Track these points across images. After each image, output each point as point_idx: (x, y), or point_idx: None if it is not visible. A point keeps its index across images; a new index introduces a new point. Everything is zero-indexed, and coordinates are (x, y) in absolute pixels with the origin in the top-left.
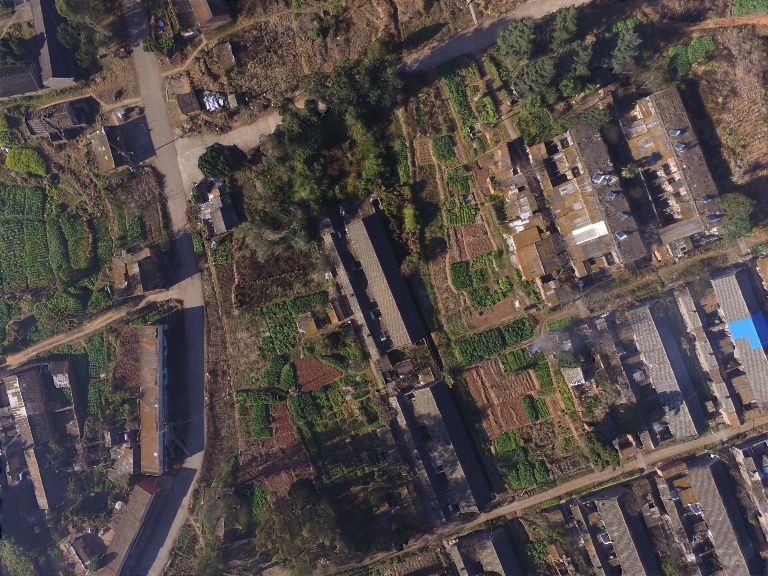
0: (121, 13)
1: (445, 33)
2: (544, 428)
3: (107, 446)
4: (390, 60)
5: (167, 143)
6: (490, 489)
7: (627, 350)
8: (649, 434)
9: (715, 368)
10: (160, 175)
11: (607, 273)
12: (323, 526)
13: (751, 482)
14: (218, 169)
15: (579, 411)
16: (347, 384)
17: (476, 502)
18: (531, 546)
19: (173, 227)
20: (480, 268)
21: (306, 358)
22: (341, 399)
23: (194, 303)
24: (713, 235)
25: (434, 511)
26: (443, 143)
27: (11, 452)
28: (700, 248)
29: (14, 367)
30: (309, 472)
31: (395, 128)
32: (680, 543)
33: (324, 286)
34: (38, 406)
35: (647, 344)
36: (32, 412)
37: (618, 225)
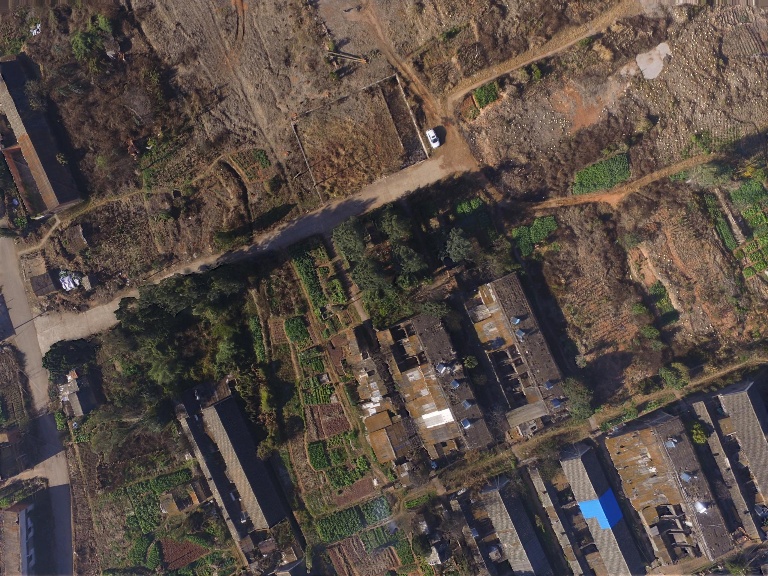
0: None
1: (294, 214)
2: None
3: None
4: (241, 241)
5: (26, 322)
6: None
7: None
8: None
9: (568, 546)
10: (20, 354)
11: (462, 450)
12: None
13: None
14: (62, 368)
15: None
16: (213, 562)
17: None
18: None
19: (35, 406)
20: (337, 447)
21: None
22: (208, 575)
23: (59, 481)
24: (564, 410)
25: None
26: (295, 325)
27: None
28: (549, 428)
29: None
30: None
31: (249, 307)
32: None
33: (187, 464)
34: None
35: (500, 525)
36: None
37: (463, 413)
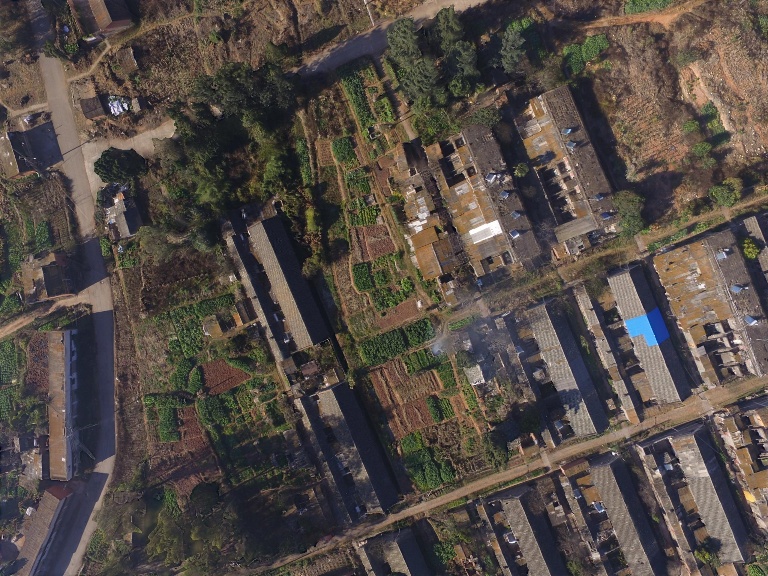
0: (26, 19)
1: (344, 35)
2: (449, 428)
3: (16, 452)
4: (290, 62)
5: (74, 148)
6: (397, 490)
7: (529, 349)
8: (550, 433)
9: (614, 366)
10: (67, 180)
11: (507, 272)
12: (216, 529)
13: (653, 479)
14: (114, 173)
15: (483, 410)
16: (254, 387)
17: (381, 503)
18: (439, 546)
19: (81, 232)
20: (382, 269)
21: (213, 361)
22: (249, 402)
23: (103, 307)
24: (612, 233)
25: None
26: (343, 144)
27: None
28: (597, 246)
29: None
30: (218, 475)
31: (297, 130)
32: (586, 541)
33: (230, 289)
34: None
35: (545, 343)
36: None
37: (512, 224)
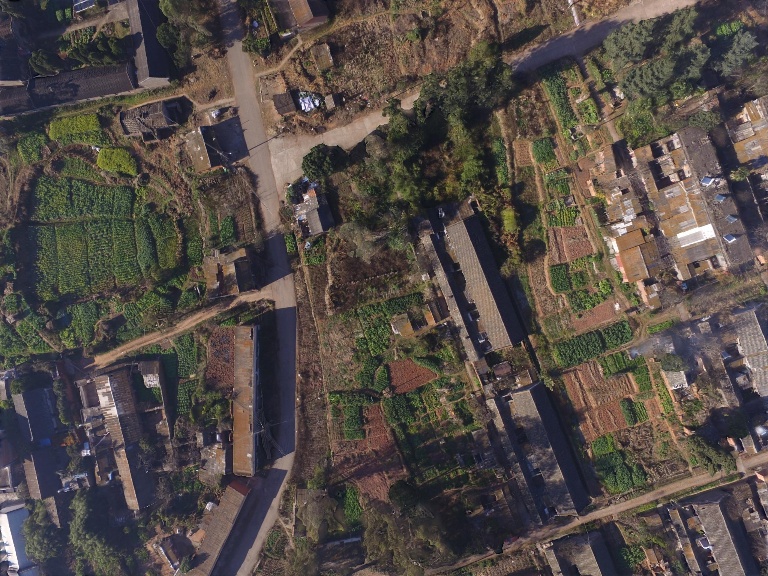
0: (215, 13)
1: (546, 35)
2: (642, 431)
3: (199, 446)
4: None
5: (260, 143)
6: (587, 492)
7: None
8: (752, 438)
9: None
10: (253, 175)
11: (709, 276)
12: (433, 529)
13: None
14: (323, 170)
15: (679, 415)
16: (442, 386)
17: (575, 505)
18: (627, 550)
19: (266, 227)
20: (580, 270)
21: (400, 360)
22: (435, 401)
23: (286, 304)
24: None
25: (528, 514)
26: (544, 145)
27: (100, 452)
28: None
29: (102, 367)
30: (402, 474)
31: (494, 130)
32: None
33: (419, 287)
34: (128, 406)
35: (752, 348)
36: (123, 412)
37: (726, 228)
